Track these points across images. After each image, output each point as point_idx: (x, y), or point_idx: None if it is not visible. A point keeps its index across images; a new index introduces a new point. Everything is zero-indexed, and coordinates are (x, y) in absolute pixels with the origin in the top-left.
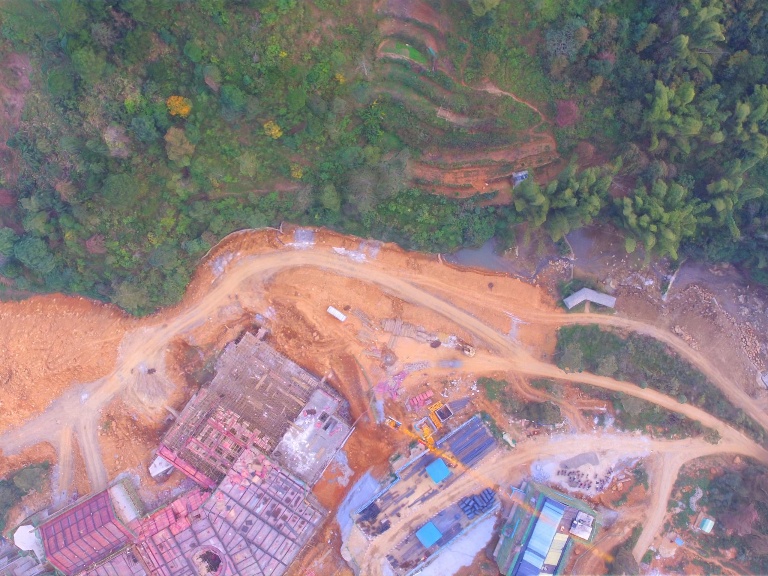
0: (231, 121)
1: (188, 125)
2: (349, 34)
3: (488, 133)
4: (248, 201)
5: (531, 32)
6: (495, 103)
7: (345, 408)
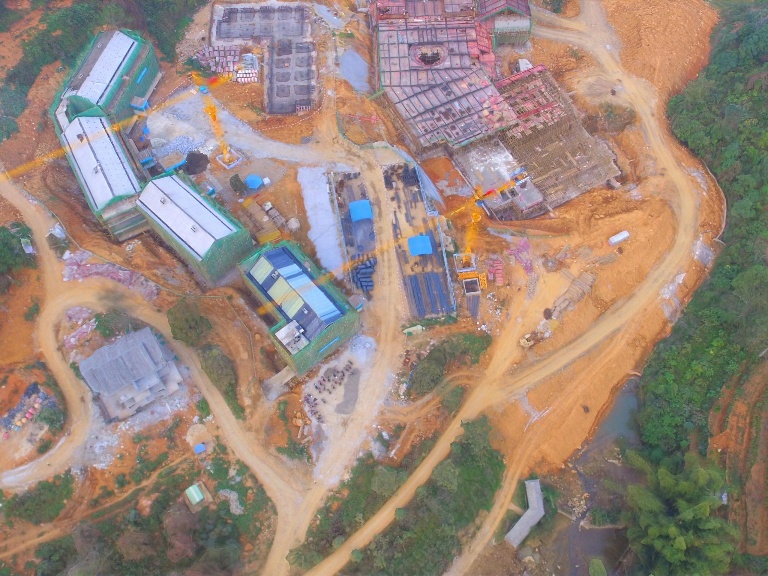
0: None
1: None
2: None
3: None
4: None
5: None
6: None
7: None
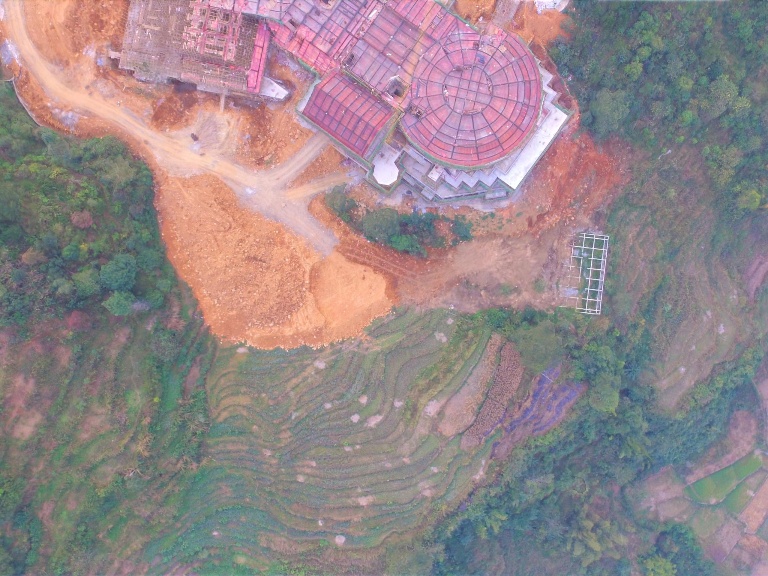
0: None
1: None
2: None
3: None
4: None
5: None
6: None
7: None
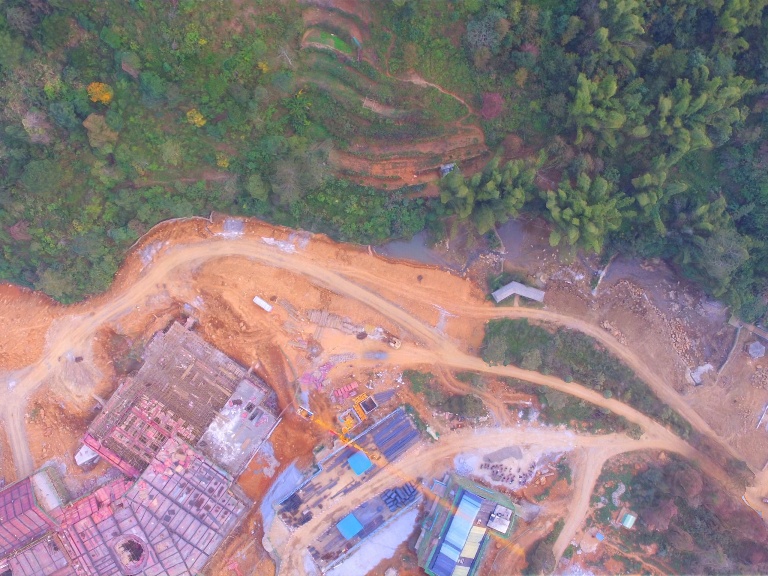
0: (153, 109)
1: (109, 112)
2: (272, 23)
3: (415, 124)
4: (176, 190)
5: (455, 23)
6: (420, 94)
7: (273, 399)
